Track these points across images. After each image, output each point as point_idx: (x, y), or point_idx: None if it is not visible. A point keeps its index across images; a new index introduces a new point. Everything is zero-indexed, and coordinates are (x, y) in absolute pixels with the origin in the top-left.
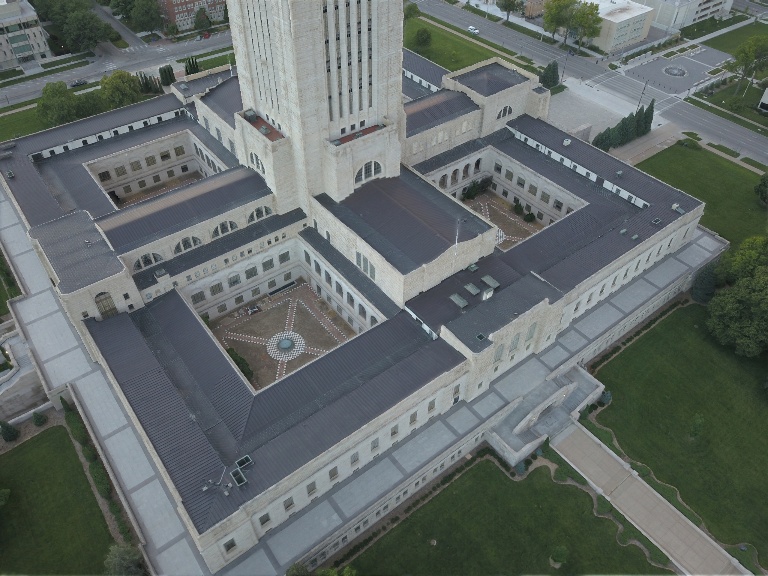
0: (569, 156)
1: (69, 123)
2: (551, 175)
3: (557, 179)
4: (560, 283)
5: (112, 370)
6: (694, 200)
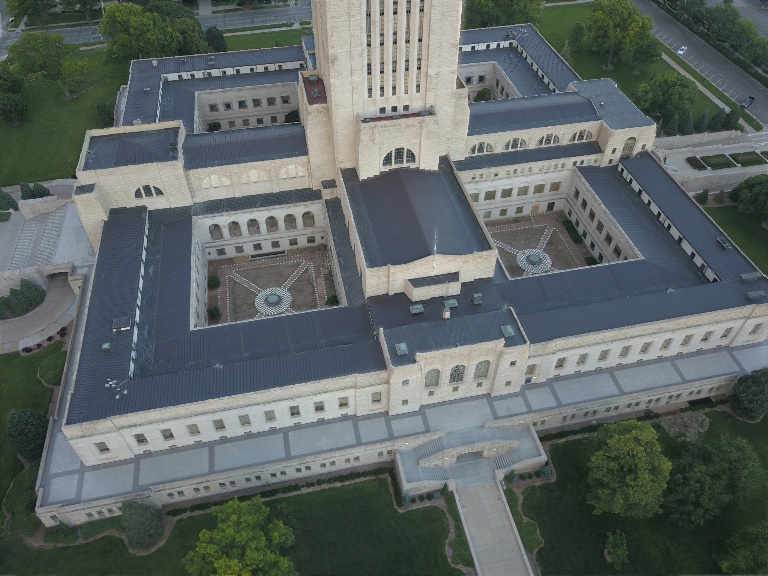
0: (153, 118)
1: (683, 317)
2: (185, 119)
3: (186, 115)
4: (290, 53)
5: (575, 76)
6: (133, 65)
